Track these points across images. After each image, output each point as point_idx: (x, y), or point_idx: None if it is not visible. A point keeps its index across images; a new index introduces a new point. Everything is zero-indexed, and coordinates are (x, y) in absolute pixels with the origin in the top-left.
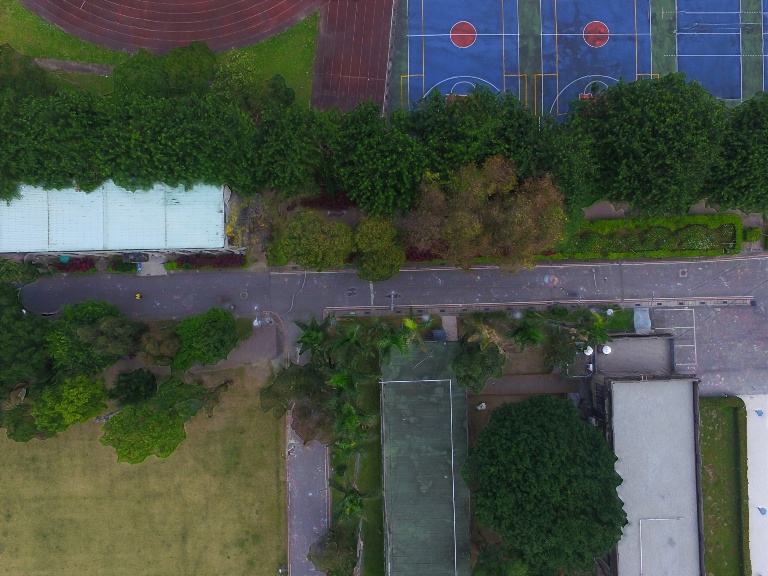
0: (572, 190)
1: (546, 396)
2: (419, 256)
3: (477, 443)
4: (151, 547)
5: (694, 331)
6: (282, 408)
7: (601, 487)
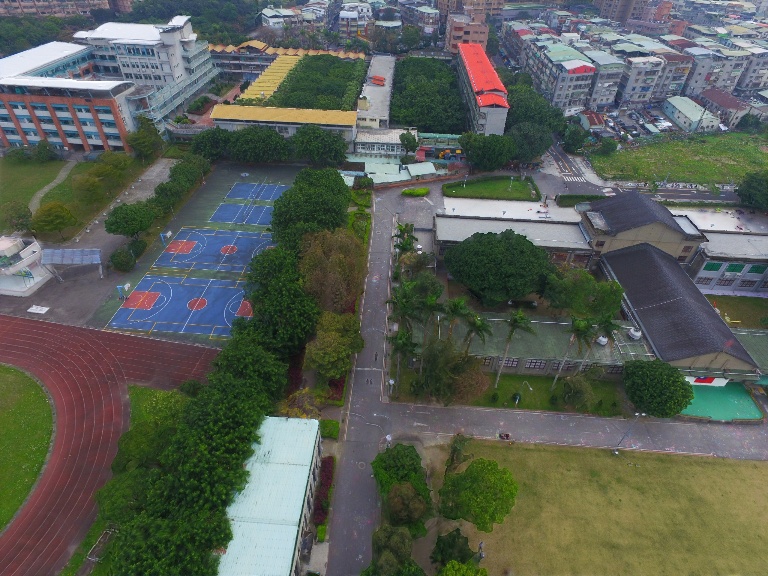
0: None
1: (445, 257)
2: None
3: (477, 288)
4: None
5: None
6: None
7: None
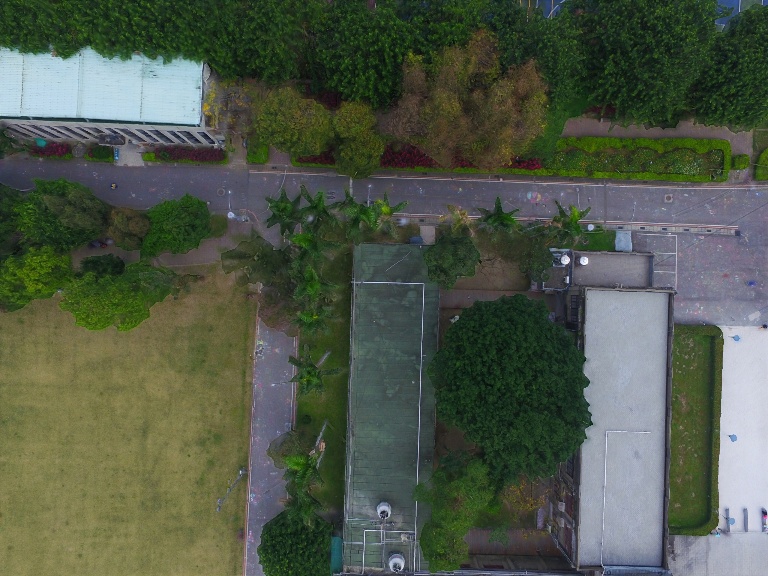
0: (556, 83)
1: (518, 295)
2: (401, 162)
3: (445, 339)
4: (111, 440)
5: (676, 258)
6: (245, 276)
7: (567, 387)
